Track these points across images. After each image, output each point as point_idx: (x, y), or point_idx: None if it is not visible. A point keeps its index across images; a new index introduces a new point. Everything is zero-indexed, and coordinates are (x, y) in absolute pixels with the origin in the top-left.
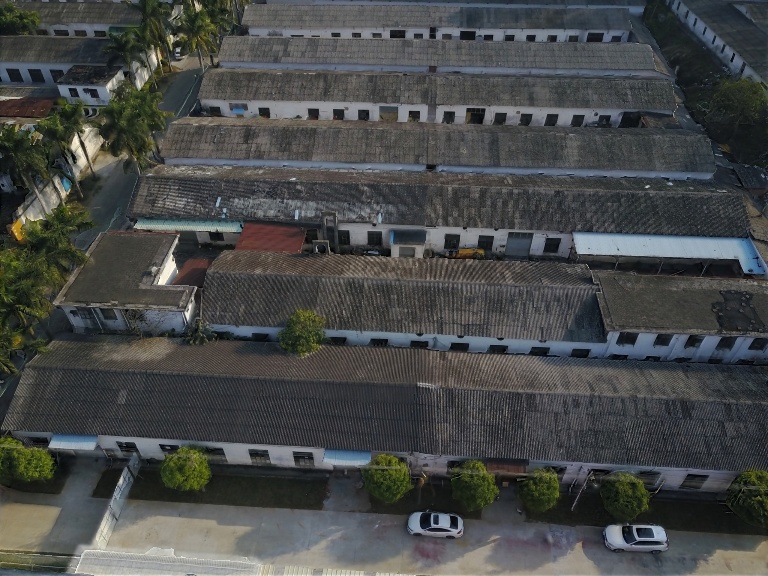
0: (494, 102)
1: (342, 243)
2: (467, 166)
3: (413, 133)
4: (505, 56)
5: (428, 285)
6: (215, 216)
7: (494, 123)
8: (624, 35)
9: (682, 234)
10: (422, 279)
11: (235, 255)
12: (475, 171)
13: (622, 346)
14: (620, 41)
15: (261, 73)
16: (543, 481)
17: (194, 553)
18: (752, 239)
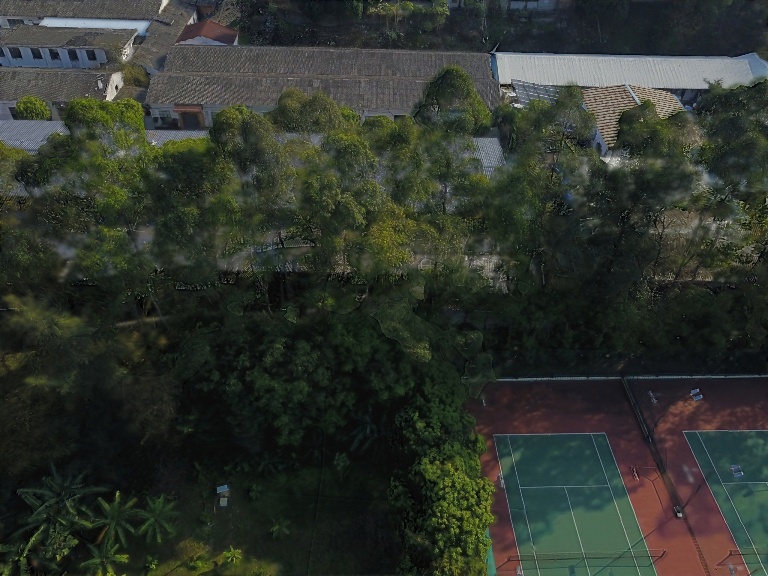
0: None
1: None
2: None
3: None
4: None
5: None
6: None
7: None
8: None
9: (112, 18)
10: None
11: None
12: None
13: (15, 59)
14: None
15: None
16: None
17: None
18: (152, 20)
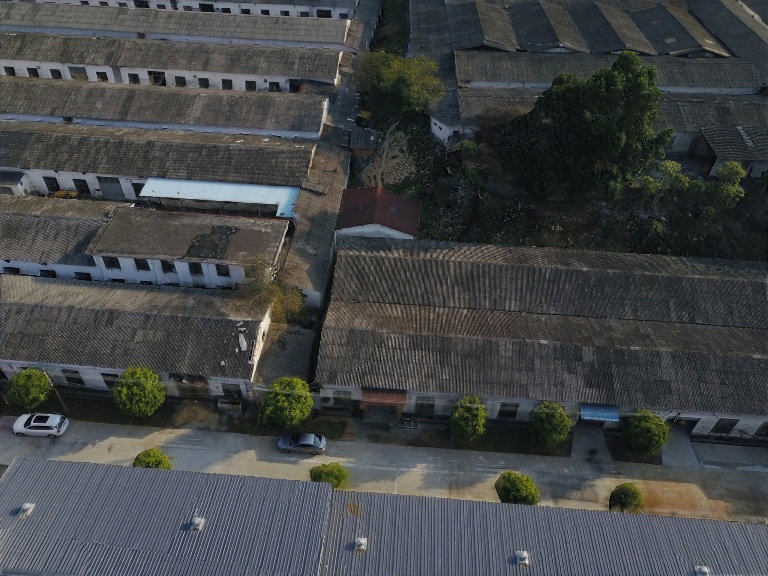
0: (171, 66)
1: None
2: (97, 119)
3: (59, 88)
4: (210, 26)
5: None
6: None
7: (176, 86)
8: (350, 13)
9: (243, 182)
10: None
11: None
12: (106, 124)
13: (111, 270)
14: (346, 18)
15: None
16: None
17: None
18: (300, 188)
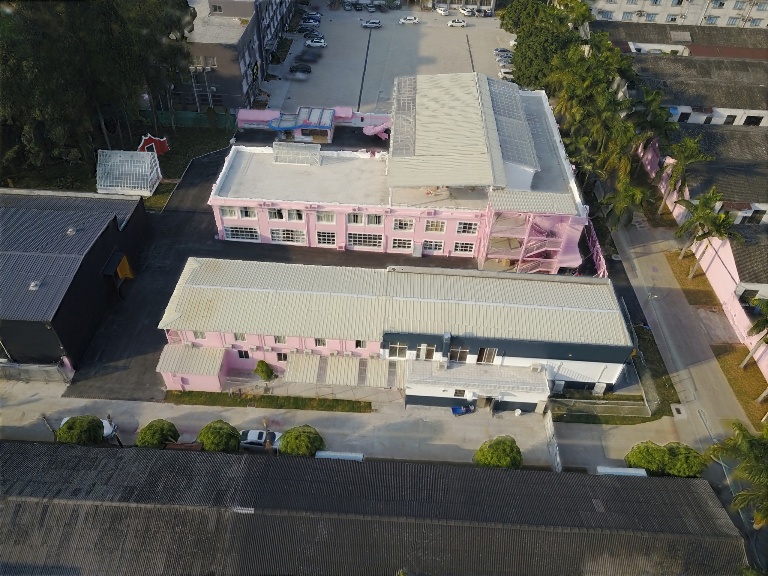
0: None
1: None
2: None
3: None
4: None
5: None
6: None
7: None
8: None
9: None
10: None
11: None
12: None
13: None
14: None
15: None
16: (154, 430)
17: (470, 423)
18: None
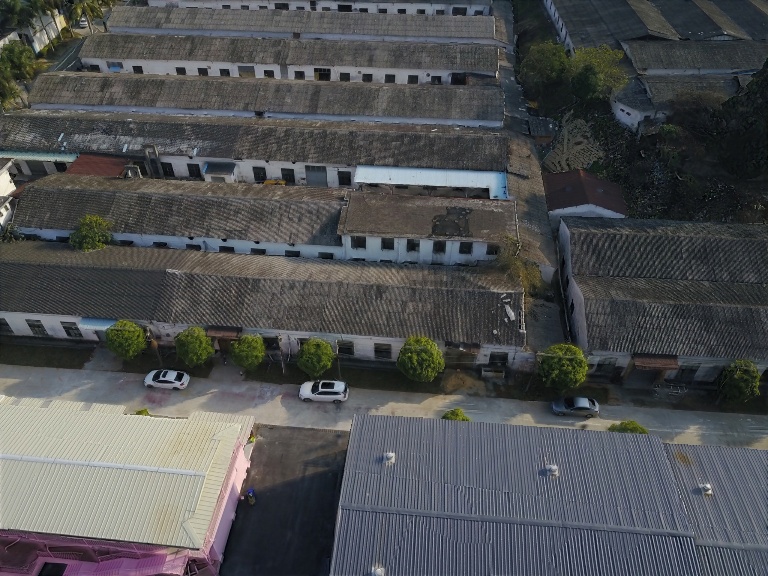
0: (337, 63)
1: (168, 175)
2: (289, 113)
3: (247, 85)
4: (362, 25)
5: (205, 199)
6: (56, 148)
7: None
8: (485, 10)
9: (449, 168)
10: (202, 195)
11: (59, 177)
12: (297, 118)
13: (356, 249)
14: (482, 15)
15: (137, 36)
16: (246, 342)
17: None
18: (506, 172)
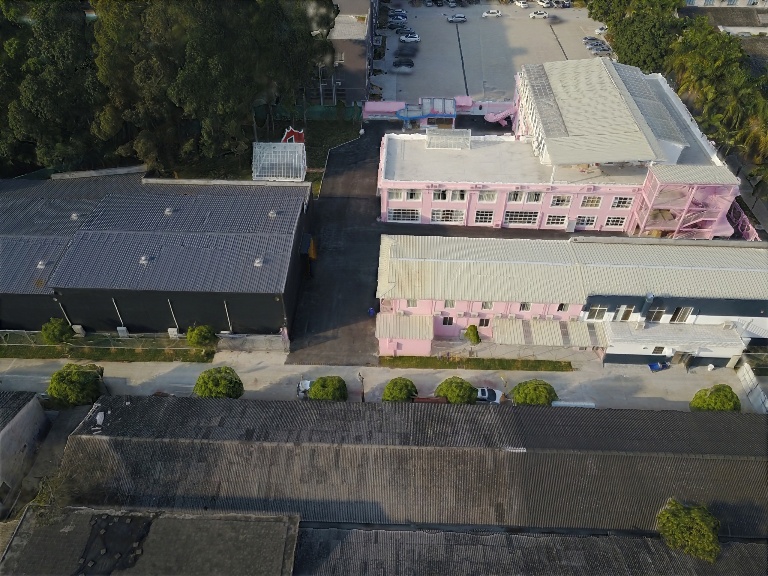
0: None
1: None
2: None
3: None
4: None
5: None
6: None
7: None
8: None
9: None
10: None
11: None
12: None
13: None
14: None
15: None
16: (400, 386)
17: (668, 378)
18: None
